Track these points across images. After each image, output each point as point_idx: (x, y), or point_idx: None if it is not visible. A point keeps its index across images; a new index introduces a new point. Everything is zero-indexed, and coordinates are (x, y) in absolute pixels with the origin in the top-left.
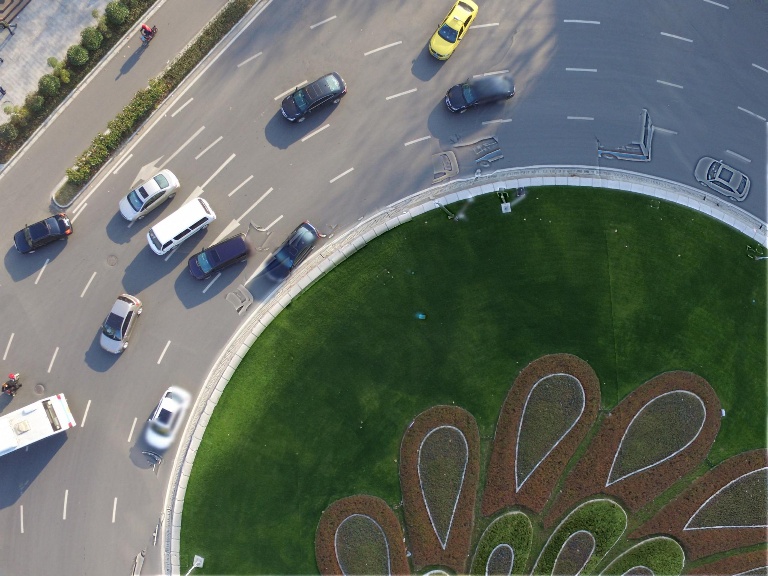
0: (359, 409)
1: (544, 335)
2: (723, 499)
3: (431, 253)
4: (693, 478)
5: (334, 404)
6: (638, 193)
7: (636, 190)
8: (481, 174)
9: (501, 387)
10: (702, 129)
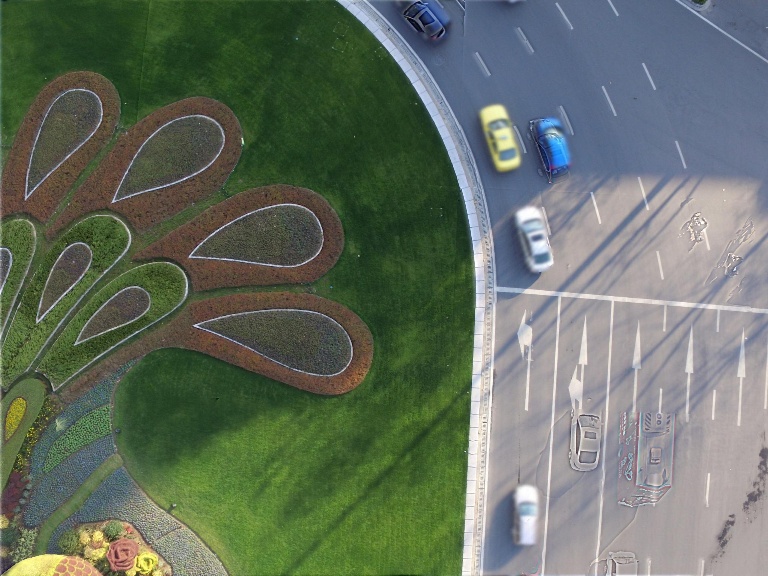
0: None
1: (75, 54)
2: (233, 230)
3: None
4: (206, 206)
5: None
6: None
7: None
8: None
9: (27, 100)
10: None
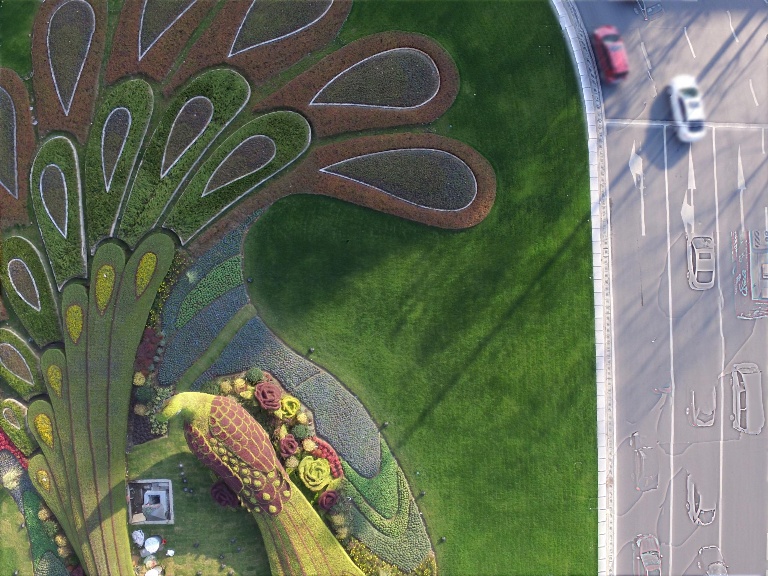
0: None
1: None
2: (352, 75)
3: None
4: (322, 55)
5: None
6: None
7: None
8: None
9: None
10: None
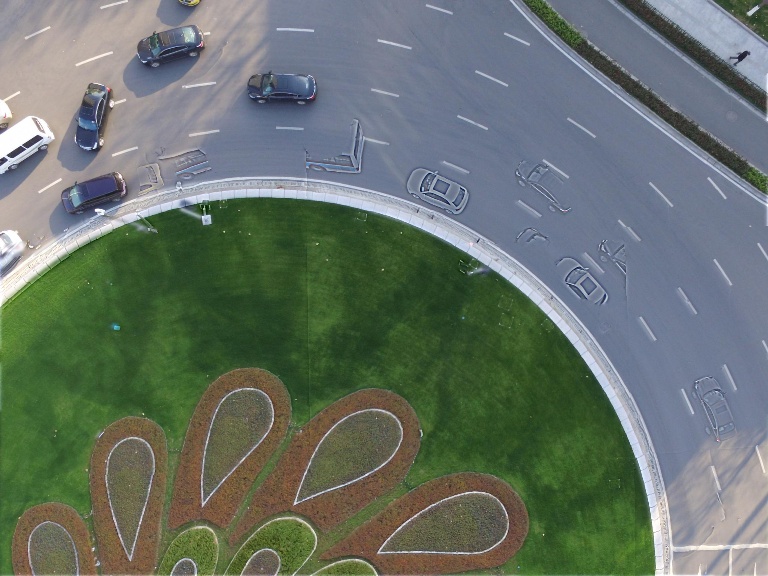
0: (54, 418)
1: (235, 349)
2: (420, 523)
3: (130, 265)
4: (390, 500)
5: (31, 412)
6: (343, 205)
7: (342, 202)
8: (182, 186)
9: (191, 400)
10: (415, 140)
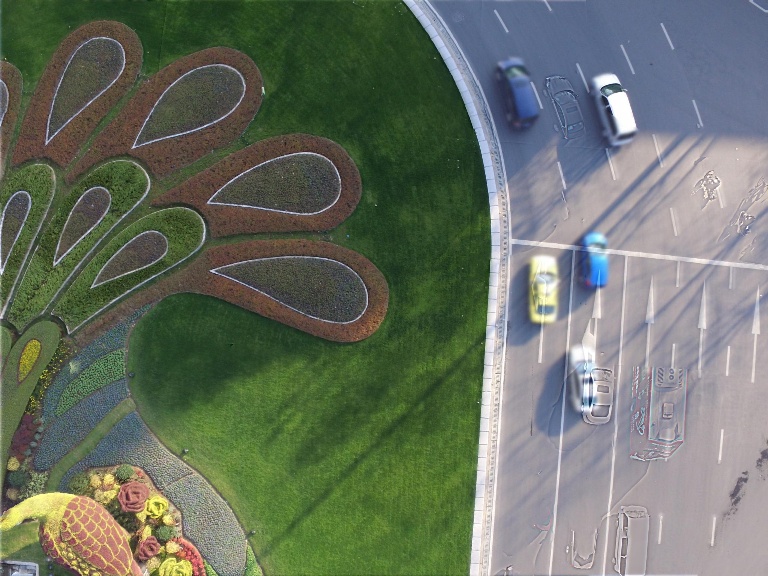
0: None
1: (99, 4)
2: (252, 177)
3: None
4: (226, 154)
5: None
6: None
7: None
8: None
9: (51, 48)
10: None
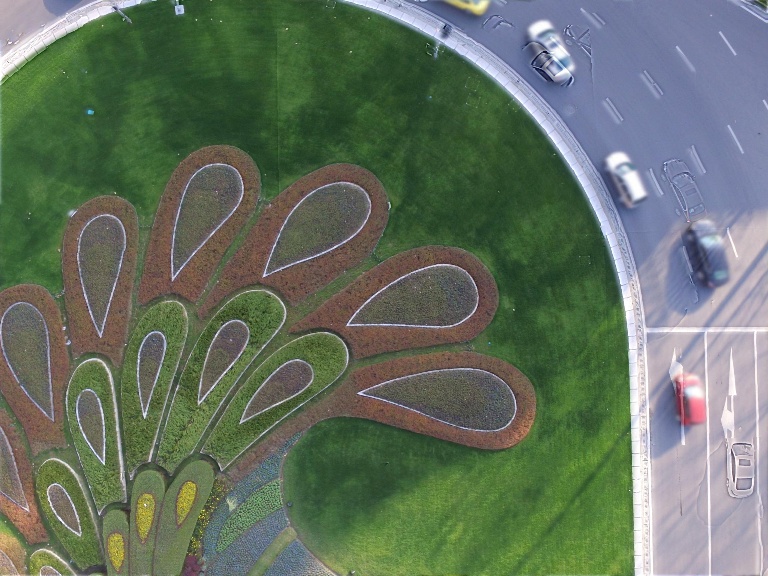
0: (28, 201)
1: (206, 127)
2: (389, 295)
3: (105, 53)
4: (359, 273)
5: (6, 197)
6: None
7: None
8: None
9: (162, 178)
10: None
